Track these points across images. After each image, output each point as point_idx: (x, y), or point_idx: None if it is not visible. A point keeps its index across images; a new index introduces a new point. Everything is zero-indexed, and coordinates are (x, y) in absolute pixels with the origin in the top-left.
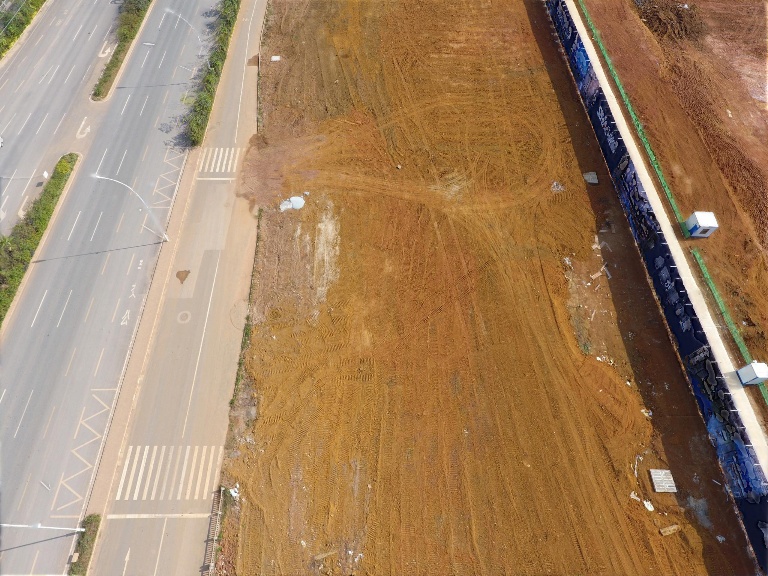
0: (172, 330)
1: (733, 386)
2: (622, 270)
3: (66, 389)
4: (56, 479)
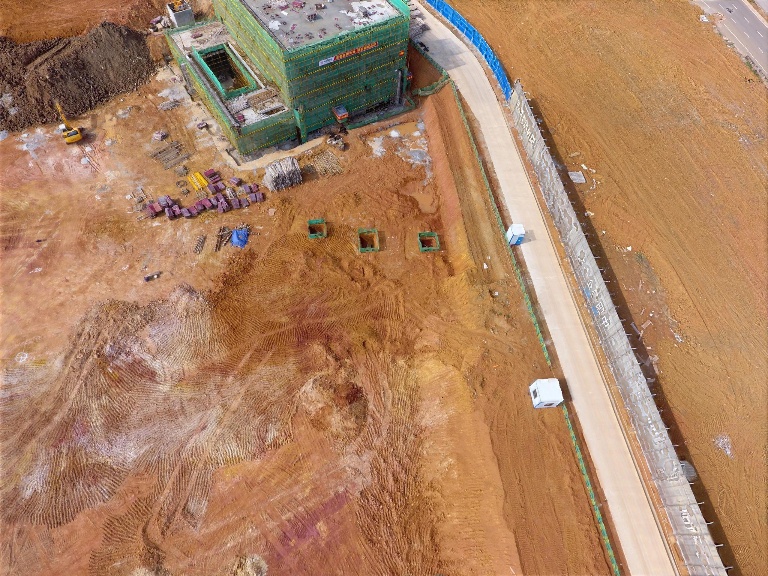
0: None
1: None
2: None
3: None
4: None
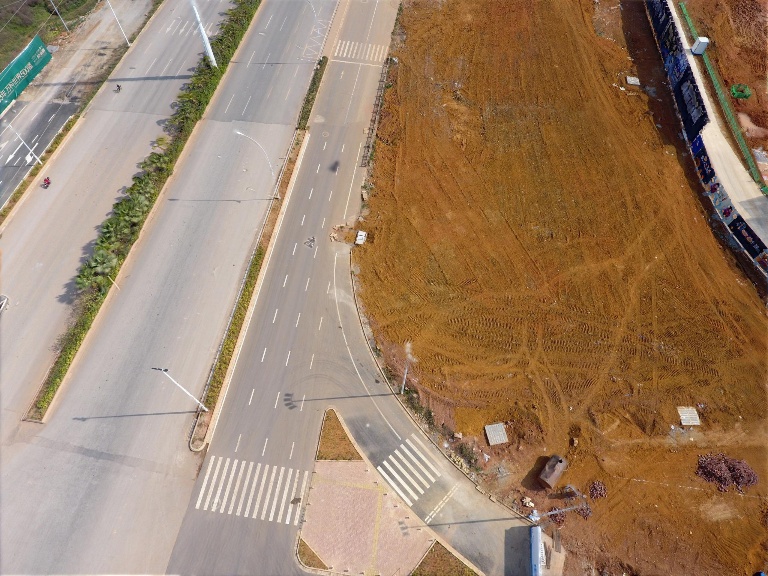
0: (358, 5)
1: None
2: (631, 7)
3: (304, 18)
4: (304, 46)
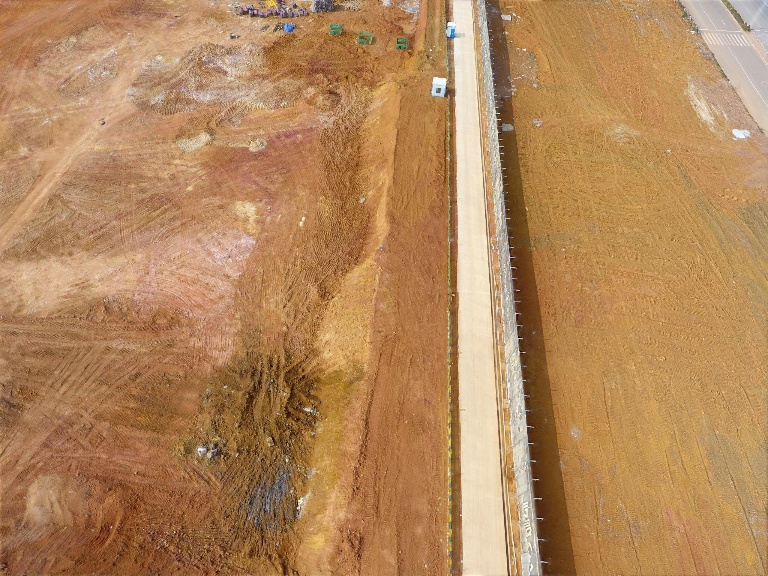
0: (767, 79)
1: (459, 34)
2: (500, 79)
3: None
4: None
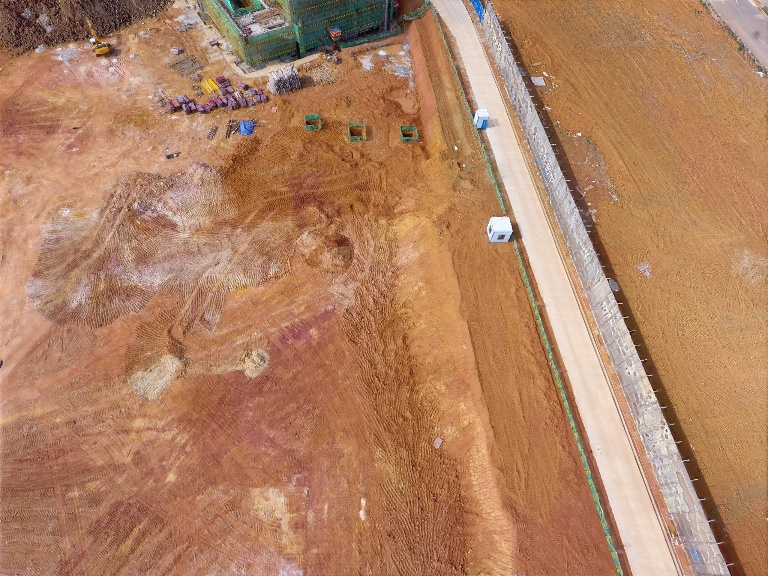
0: None
1: (490, 120)
2: (567, 194)
3: None
4: None
